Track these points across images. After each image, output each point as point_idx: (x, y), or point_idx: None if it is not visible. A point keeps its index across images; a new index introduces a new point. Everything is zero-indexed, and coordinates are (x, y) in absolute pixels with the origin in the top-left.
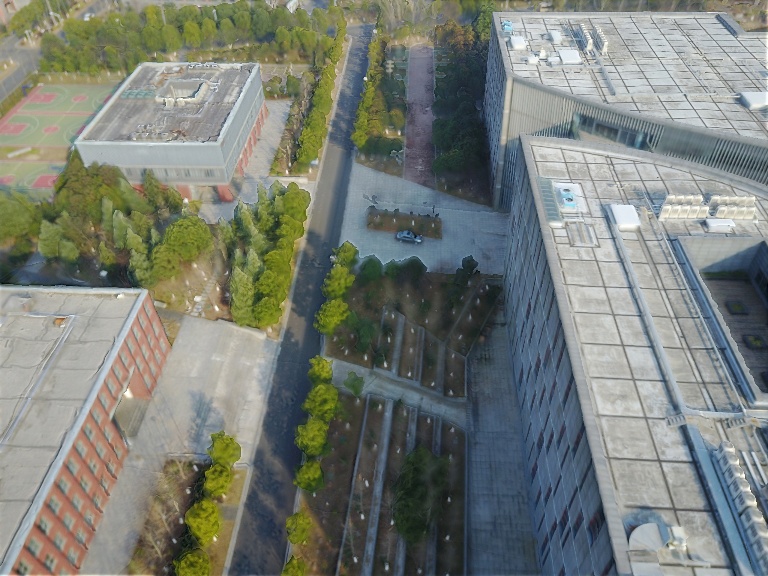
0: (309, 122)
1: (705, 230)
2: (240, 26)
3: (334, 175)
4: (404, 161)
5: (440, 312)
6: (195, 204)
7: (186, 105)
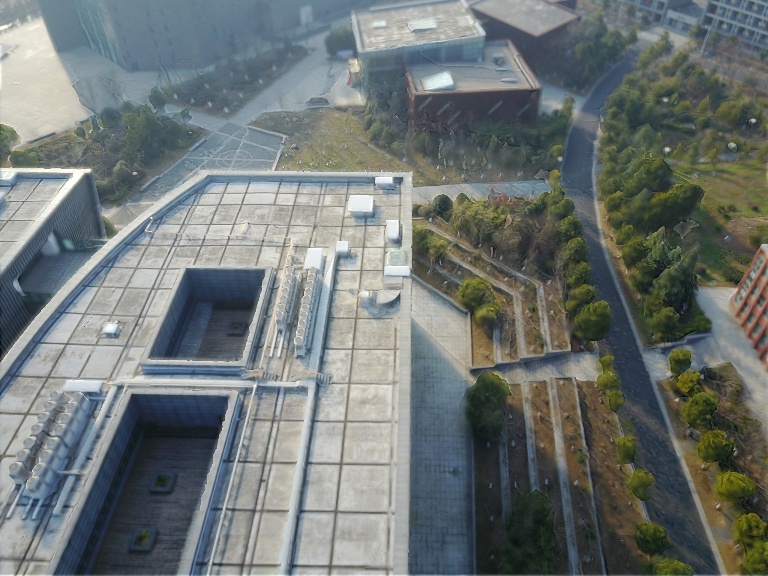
0: None
1: None
2: None
3: None
4: None
5: None
6: None
7: None
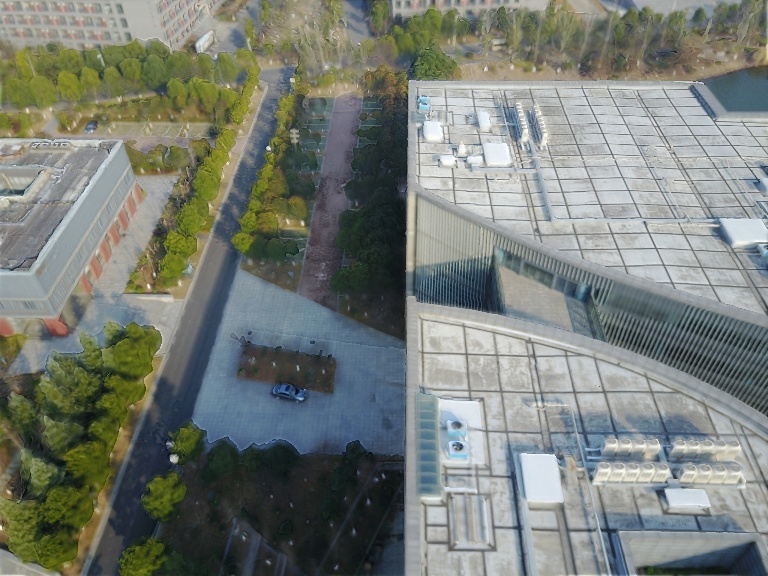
0: (181, 218)
1: (663, 507)
2: (128, 76)
3: (209, 289)
4: (302, 266)
5: (313, 524)
6: (17, 340)
7: (10, 206)
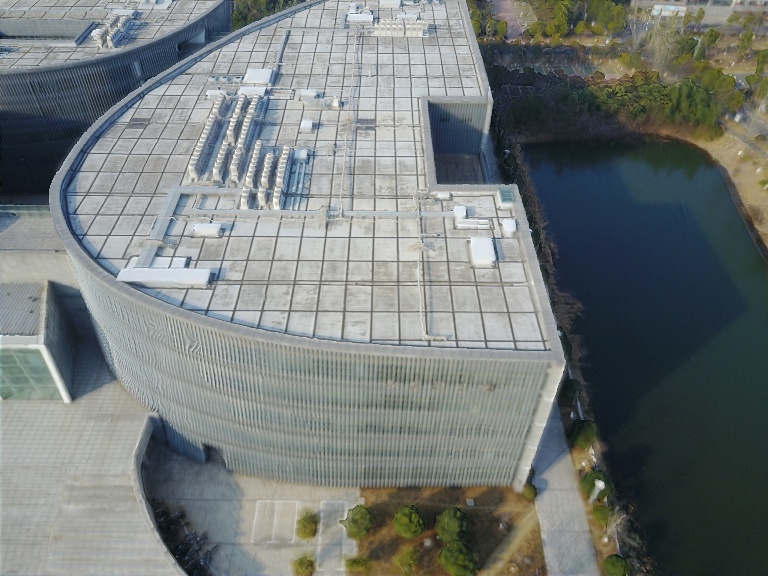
0: None
1: None
2: None
3: None
4: None
5: None
6: None
7: None
